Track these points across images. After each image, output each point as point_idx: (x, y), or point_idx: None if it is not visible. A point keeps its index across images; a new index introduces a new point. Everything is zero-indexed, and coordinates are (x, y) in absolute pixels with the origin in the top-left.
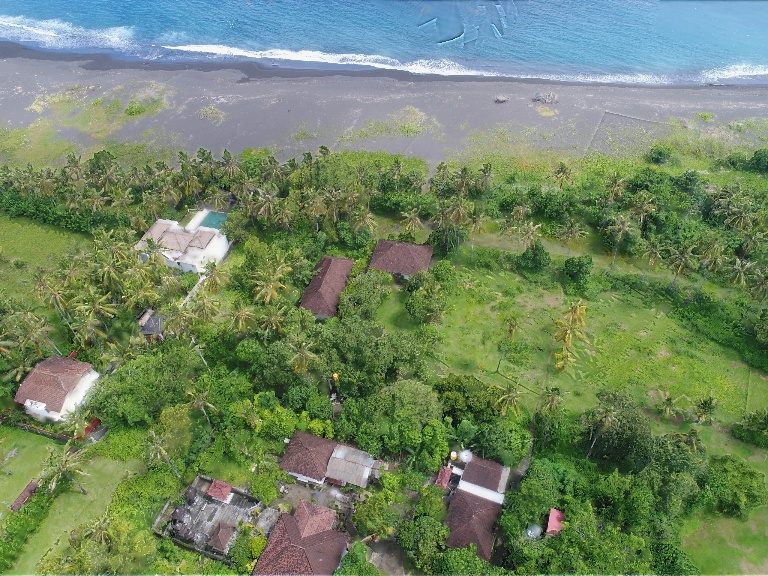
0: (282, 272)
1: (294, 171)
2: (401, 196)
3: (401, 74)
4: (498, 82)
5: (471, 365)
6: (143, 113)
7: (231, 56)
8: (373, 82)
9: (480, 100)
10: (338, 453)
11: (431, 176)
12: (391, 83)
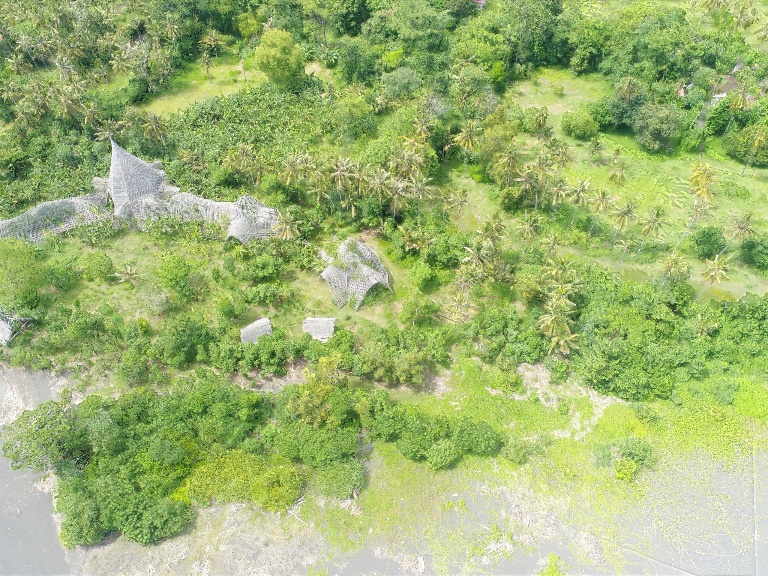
0: None
1: None
2: None
3: None
4: None
5: (764, 179)
6: None
7: None
8: None
9: None
10: None
11: None
12: None
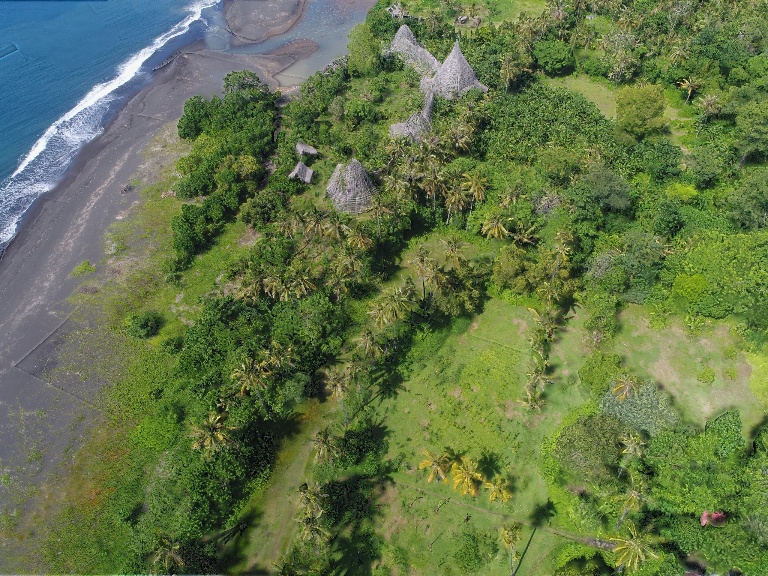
0: None
1: None
2: None
3: None
4: None
5: None
6: None
7: None
8: None
9: None
10: None
11: None
12: None
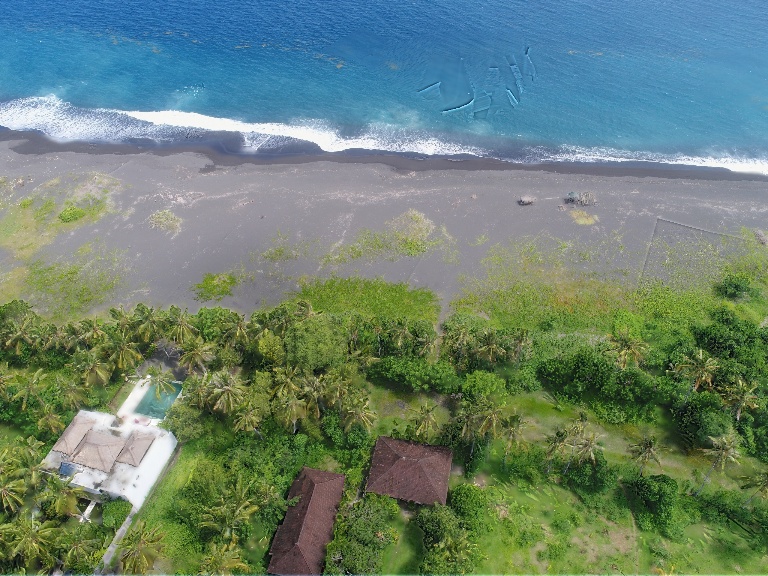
0: (243, 520)
1: (264, 330)
2: (407, 365)
3: (400, 158)
4: (519, 171)
5: None
6: (81, 219)
7: (194, 135)
8: (366, 172)
9: (500, 201)
10: None
11: (443, 319)
12: (388, 173)
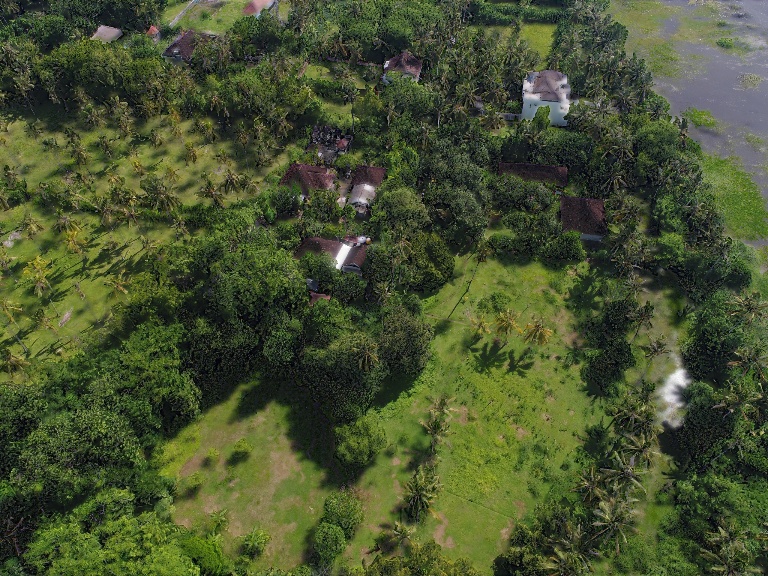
0: None
1: None
2: None
3: None
4: None
5: None
6: (725, 48)
7: None
8: None
9: None
10: (368, 186)
11: None
12: None
